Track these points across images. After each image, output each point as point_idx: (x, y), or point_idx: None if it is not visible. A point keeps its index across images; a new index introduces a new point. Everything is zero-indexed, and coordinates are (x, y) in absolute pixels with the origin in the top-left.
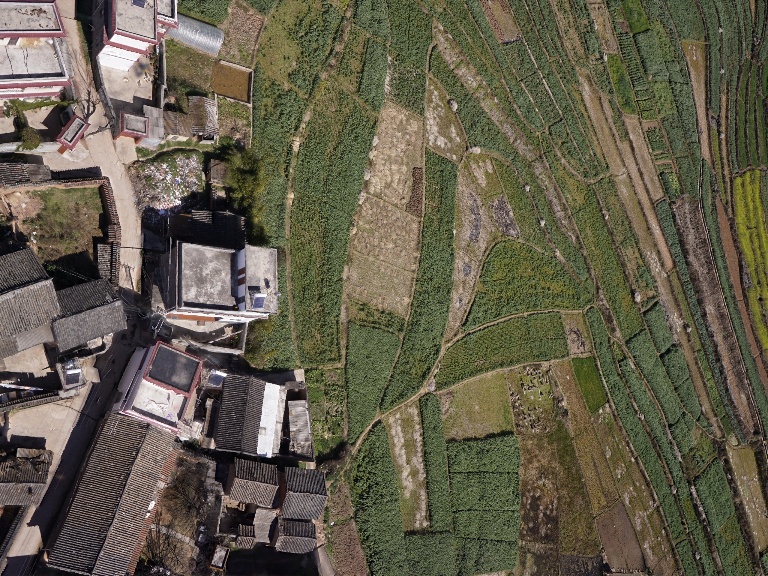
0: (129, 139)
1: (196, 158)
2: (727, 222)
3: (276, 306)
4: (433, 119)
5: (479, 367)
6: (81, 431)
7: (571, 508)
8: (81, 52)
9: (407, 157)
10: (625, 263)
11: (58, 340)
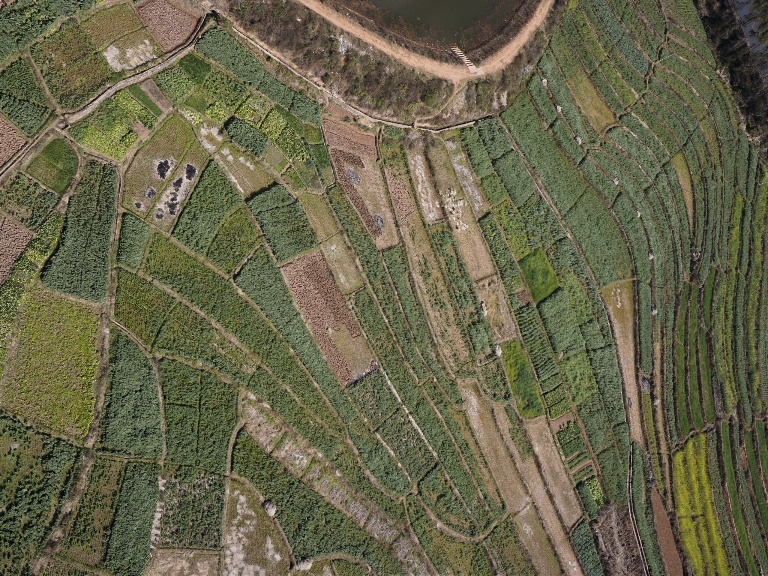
0: None
1: None
2: (666, 518)
3: None
4: (237, 542)
5: None
6: None
7: None
8: None
9: None
10: None
11: None
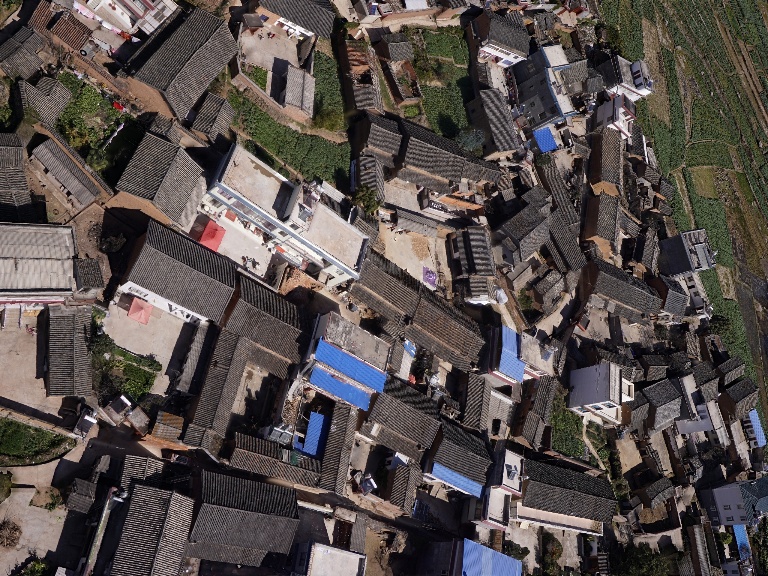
0: (574, 13)
1: (593, 27)
2: None
3: (653, 89)
4: (659, 28)
5: (700, 162)
6: (587, 137)
7: (749, 250)
8: None
9: (654, 46)
10: (752, 124)
11: (588, 88)
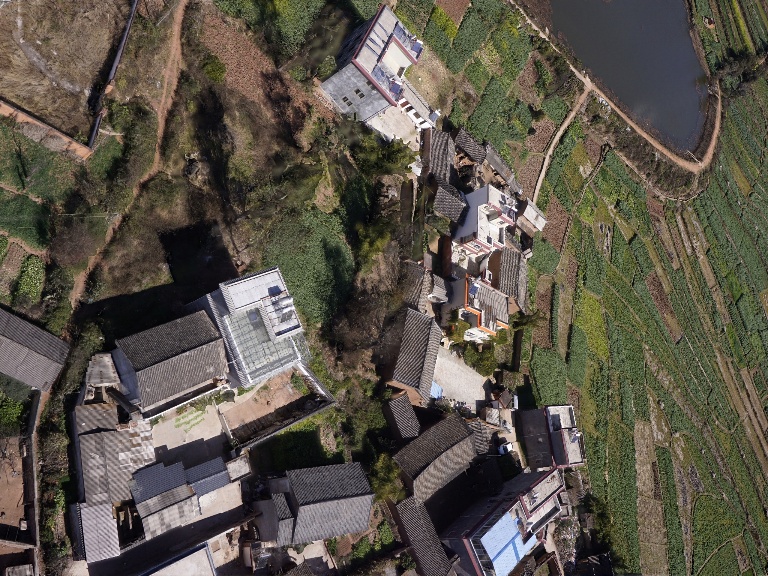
0: None
1: (576, 514)
2: None
3: None
4: (653, 420)
5: None
6: None
7: None
8: (523, 463)
9: (648, 457)
10: (758, 489)
11: None
